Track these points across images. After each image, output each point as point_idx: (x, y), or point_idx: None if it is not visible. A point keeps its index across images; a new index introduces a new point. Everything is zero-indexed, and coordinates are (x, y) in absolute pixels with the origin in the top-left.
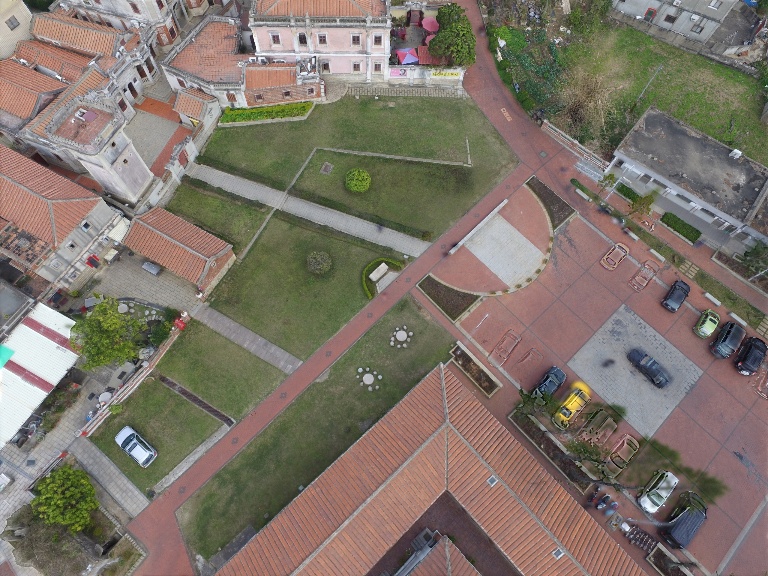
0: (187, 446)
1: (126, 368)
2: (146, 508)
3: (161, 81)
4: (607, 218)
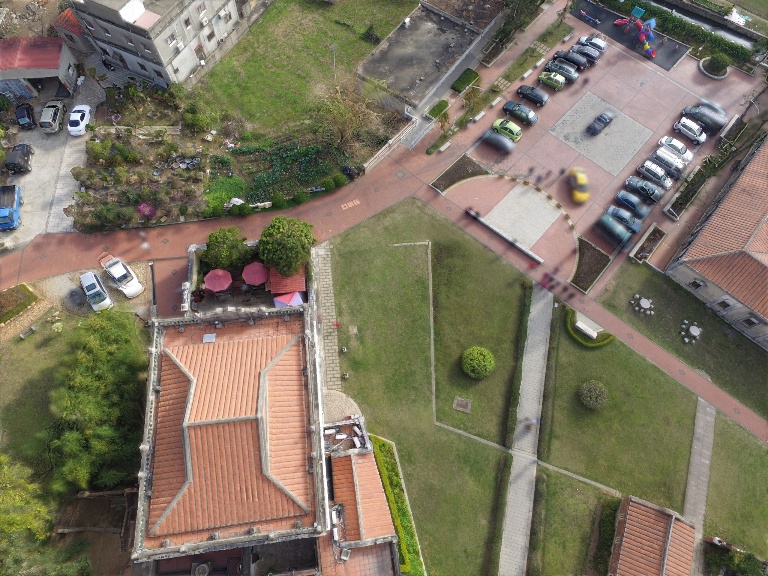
0: None
1: None
2: None
3: None
4: (465, 132)
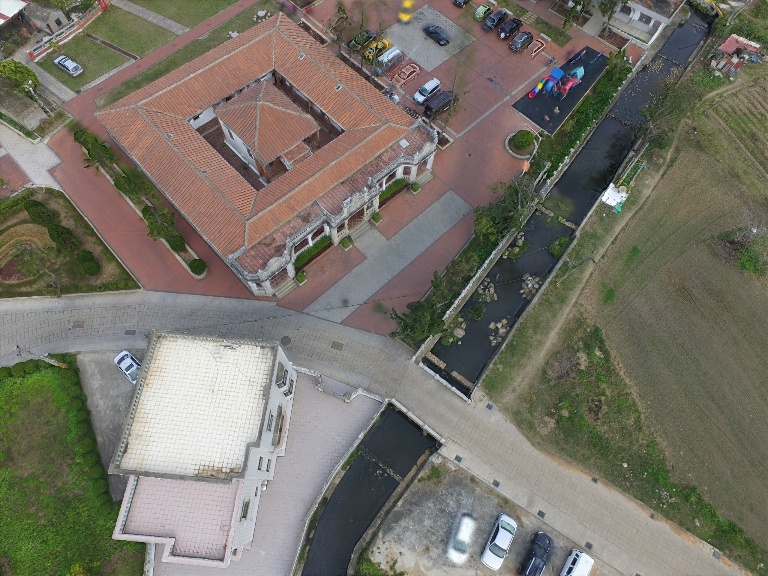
0: (105, 69)
1: (61, 18)
2: (75, 97)
3: None
4: None
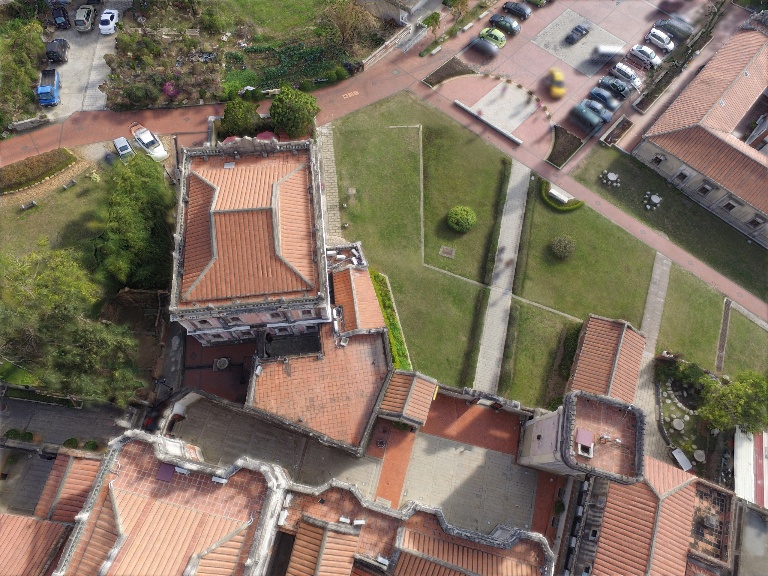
0: (761, 333)
1: None
2: None
3: (346, 479)
4: (454, 40)
